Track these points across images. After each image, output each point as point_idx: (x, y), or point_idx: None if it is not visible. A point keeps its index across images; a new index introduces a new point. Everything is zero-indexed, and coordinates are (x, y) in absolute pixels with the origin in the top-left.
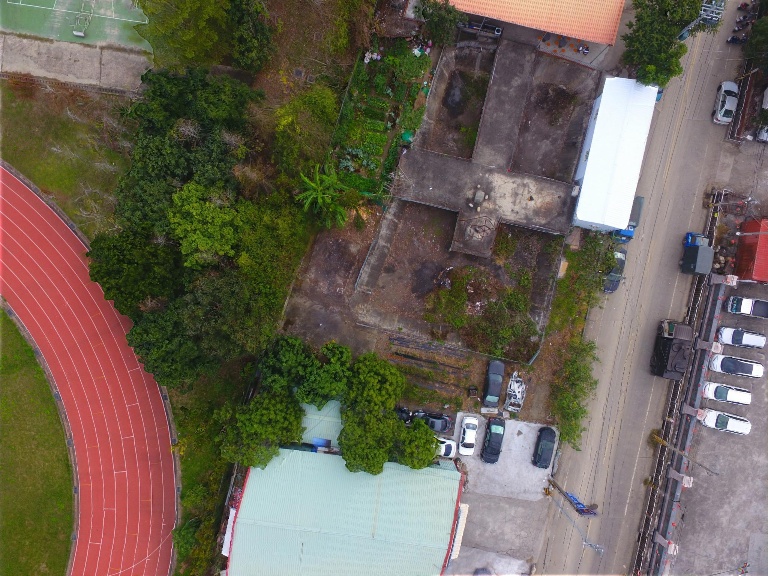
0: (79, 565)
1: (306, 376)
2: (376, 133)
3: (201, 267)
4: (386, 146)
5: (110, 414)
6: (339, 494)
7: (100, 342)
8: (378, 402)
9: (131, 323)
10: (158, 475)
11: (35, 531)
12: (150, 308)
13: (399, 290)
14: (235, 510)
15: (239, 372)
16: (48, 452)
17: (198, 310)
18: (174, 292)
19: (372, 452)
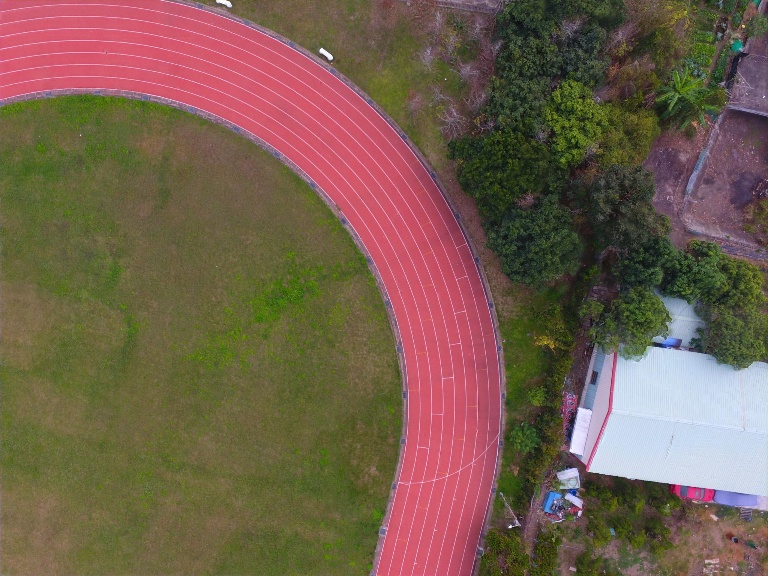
0: (408, 469)
1: (682, 269)
2: (706, 44)
3: (567, 166)
4: (714, 57)
5: (438, 321)
6: (705, 388)
7: (429, 251)
8: (755, 295)
9: (459, 232)
10: (484, 381)
11: (366, 435)
12: (529, 203)
13: (718, 201)
14: (585, 409)
15: (565, 280)
16: (379, 358)
17: (612, 194)
18: (541, 190)
19: (757, 341)
